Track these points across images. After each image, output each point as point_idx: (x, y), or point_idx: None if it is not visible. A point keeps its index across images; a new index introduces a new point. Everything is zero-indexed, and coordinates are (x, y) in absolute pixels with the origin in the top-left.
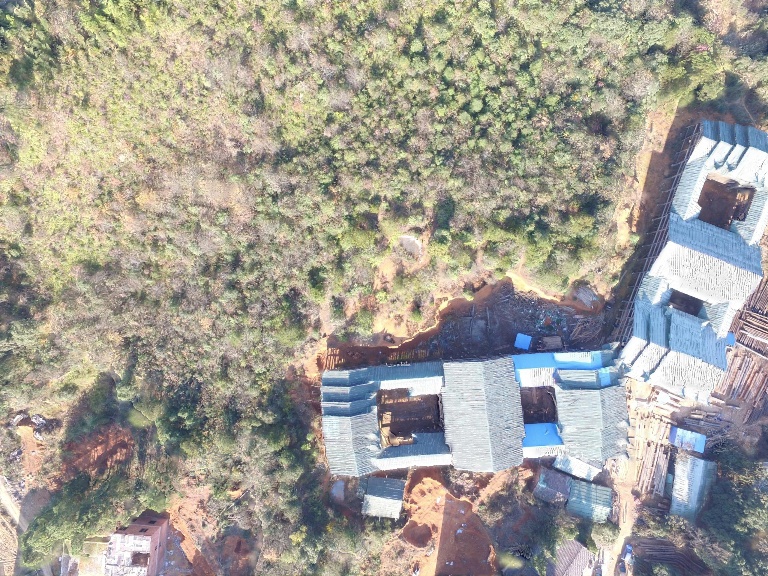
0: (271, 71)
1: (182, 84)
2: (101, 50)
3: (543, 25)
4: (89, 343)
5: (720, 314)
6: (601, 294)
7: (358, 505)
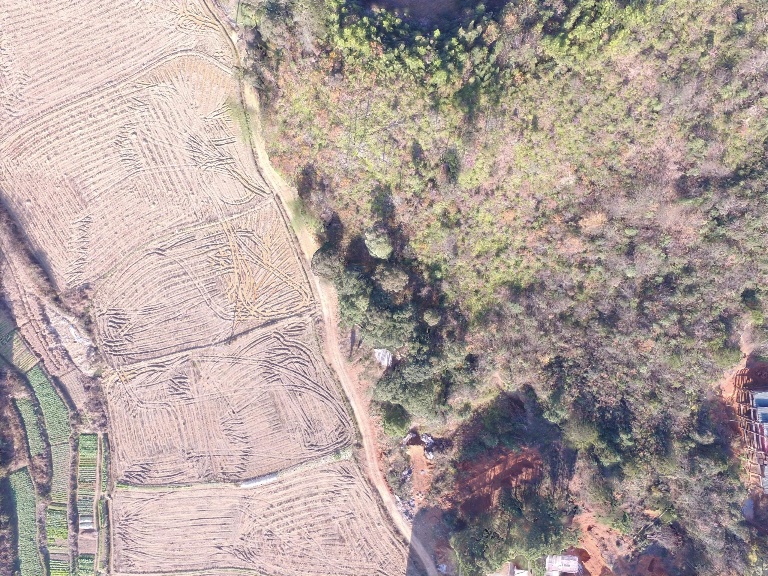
0: (725, 95)
1: (631, 107)
2: (553, 74)
3: None
4: (513, 364)
5: None
6: None
7: None
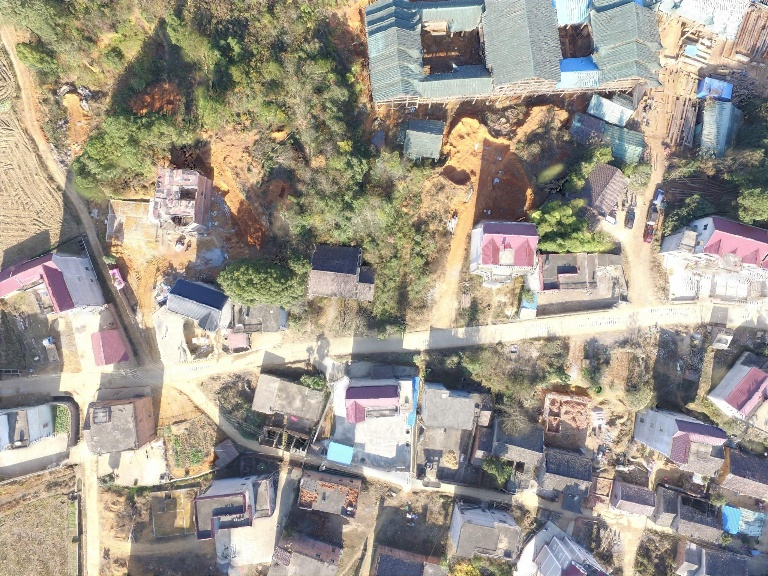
0: None
1: None
2: None
3: None
4: None
5: None
6: None
7: (399, 151)
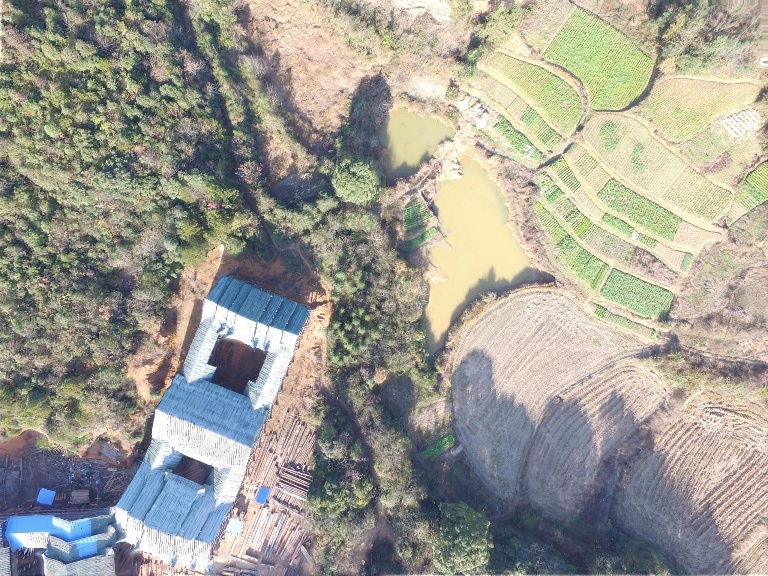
0: None
1: None
2: None
3: (51, 183)
4: None
5: (222, 480)
6: (126, 450)
7: None
